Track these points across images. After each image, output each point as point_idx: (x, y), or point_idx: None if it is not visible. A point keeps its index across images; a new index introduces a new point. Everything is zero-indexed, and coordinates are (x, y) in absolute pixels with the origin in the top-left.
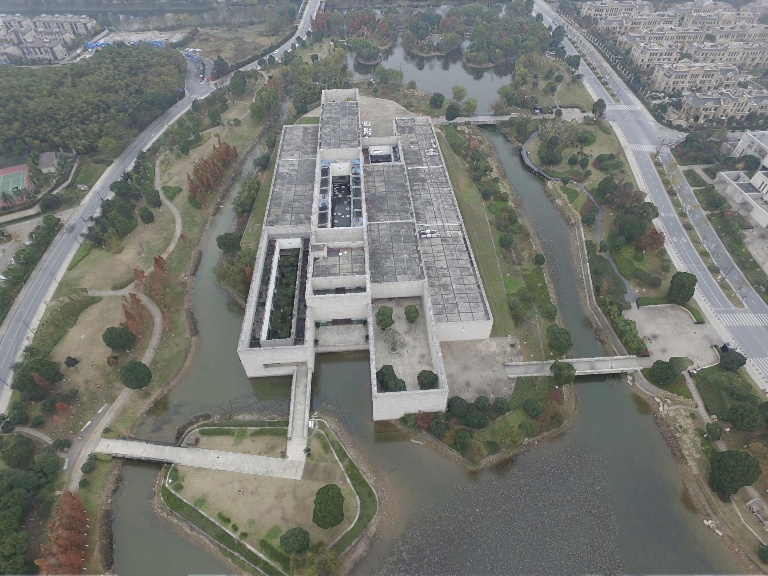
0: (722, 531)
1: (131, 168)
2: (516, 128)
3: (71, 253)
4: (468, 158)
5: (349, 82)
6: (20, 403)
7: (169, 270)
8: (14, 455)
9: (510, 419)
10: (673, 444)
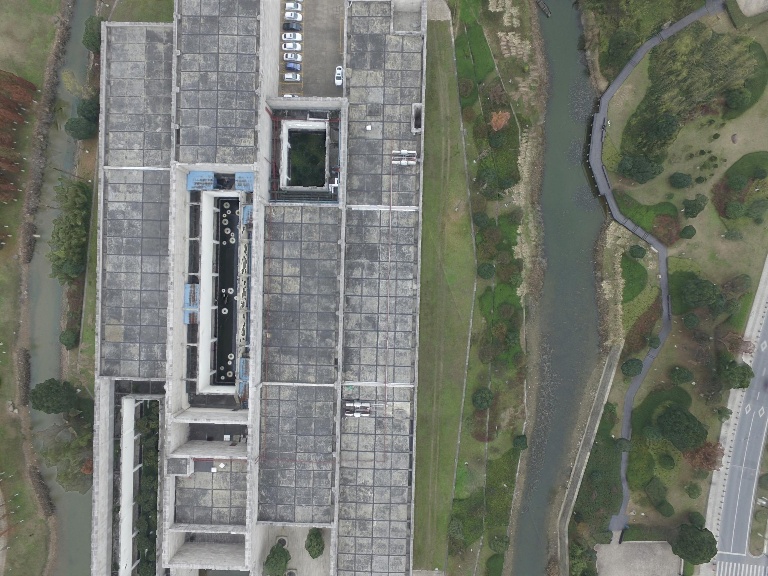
0: None
1: None
2: (609, 43)
3: None
4: (478, 158)
5: None
6: None
7: None
8: None
9: None
10: None
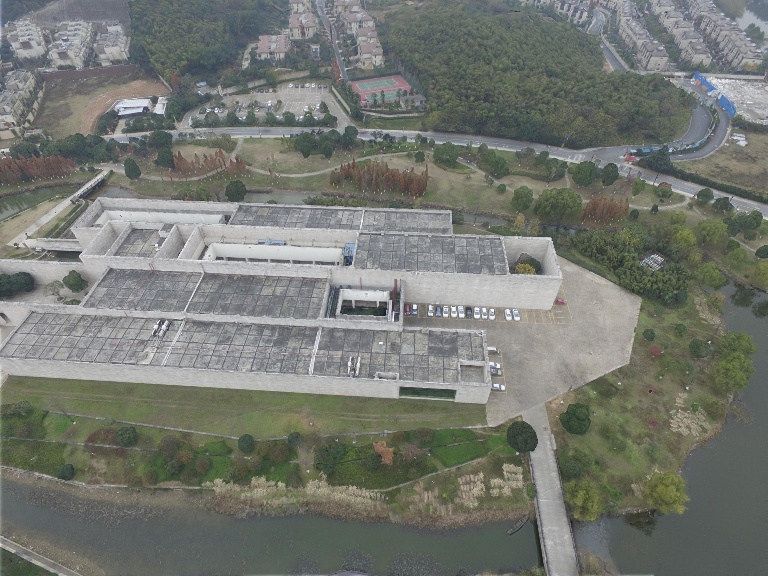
0: None
1: (413, 141)
2: None
3: None
4: None
5: (679, 299)
6: None
7: (249, 177)
8: (108, 142)
9: None
10: None
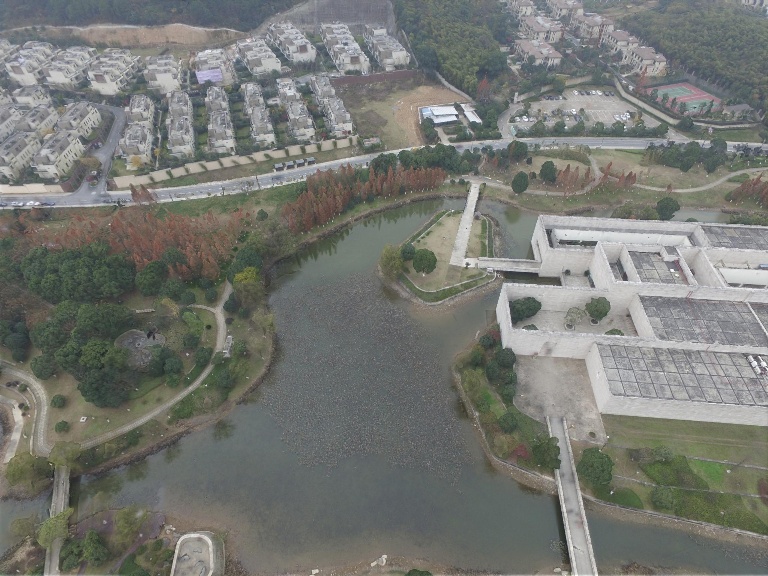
0: (374, 568)
1: None
2: None
3: (634, 147)
4: None
5: None
6: (500, 151)
7: (632, 192)
8: (466, 153)
9: (498, 406)
10: (470, 575)
